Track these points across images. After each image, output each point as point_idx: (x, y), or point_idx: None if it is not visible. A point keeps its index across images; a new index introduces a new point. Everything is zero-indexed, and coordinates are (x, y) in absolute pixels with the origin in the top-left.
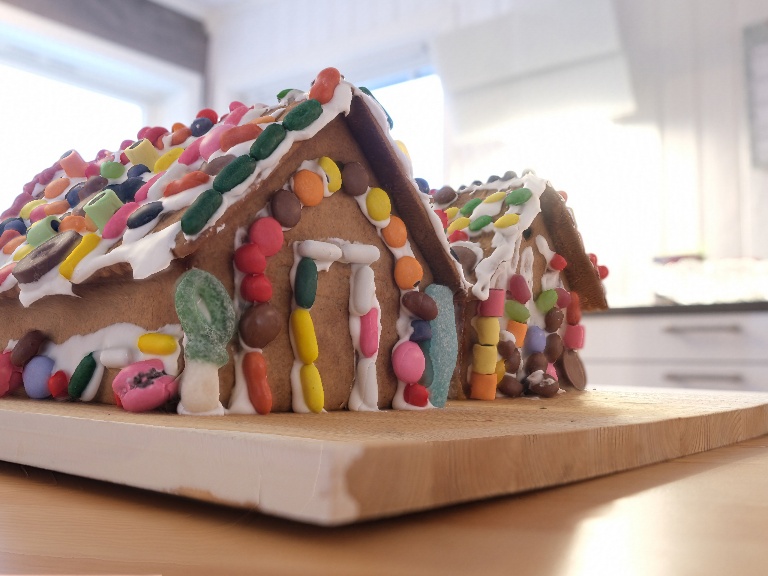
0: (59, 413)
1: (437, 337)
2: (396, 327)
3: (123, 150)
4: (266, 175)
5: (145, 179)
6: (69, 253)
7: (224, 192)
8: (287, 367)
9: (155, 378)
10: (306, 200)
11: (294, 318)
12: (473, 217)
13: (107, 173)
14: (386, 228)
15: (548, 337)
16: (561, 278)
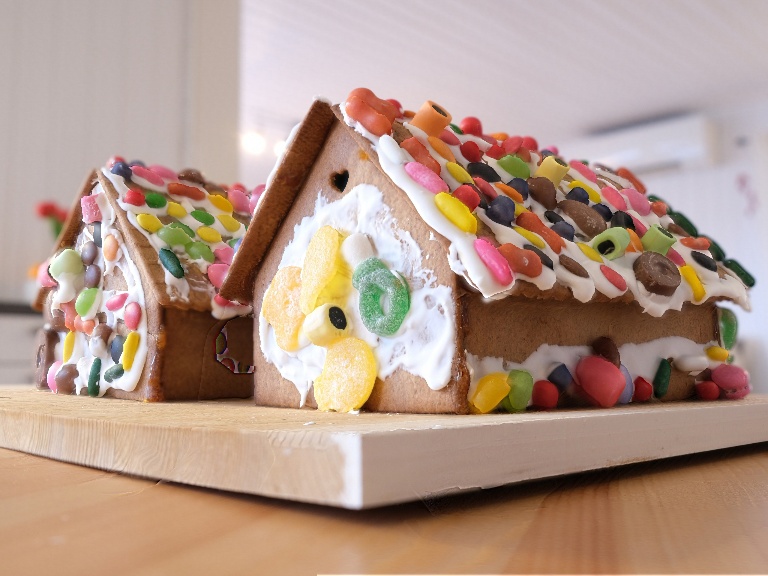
0: None
1: None
2: None
3: None
4: None
5: None
6: None
7: None
8: None
9: None
10: None
11: None
12: None
13: None
14: None
15: None
16: None
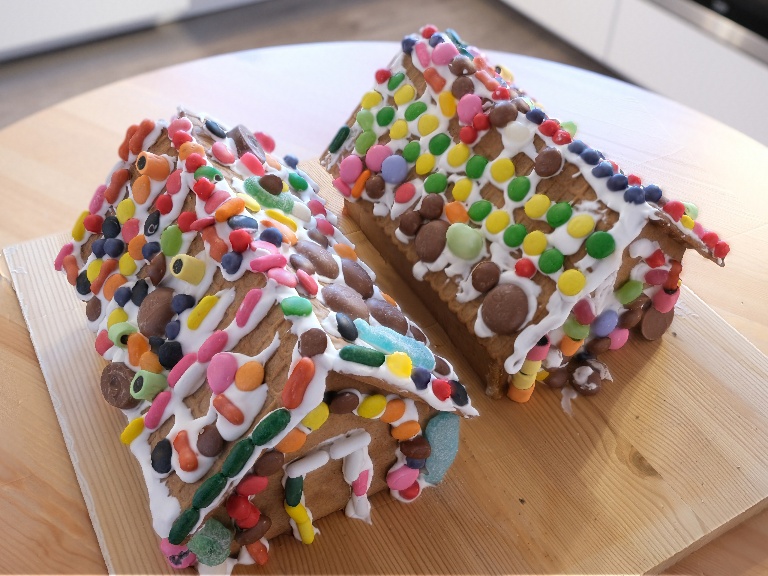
0: (127, 575)
1: (433, 457)
2: (395, 453)
3: (188, 175)
4: (237, 483)
5: (180, 337)
6: (130, 407)
7: (201, 508)
8: (286, 519)
9: (183, 558)
10: None
11: None
12: (551, 241)
13: (166, 251)
14: (381, 416)
15: (625, 313)
16: (666, 251)
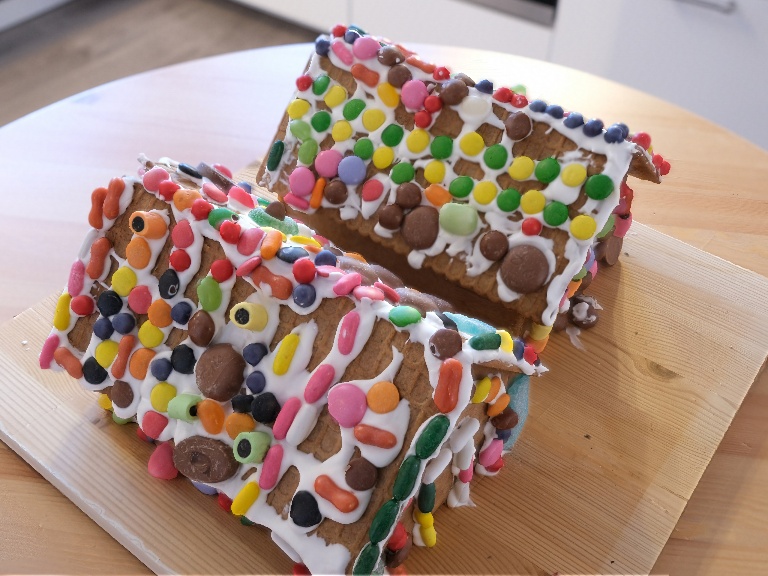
0: None
1: None
2: (483, 432)
3: (199, 223)
4: None
5: (269, 387)
6: (228, 477)
7: None
8: None
9: None
10: None
11: (418, 518)
12: (549, 196)
13: (208, 306)
14: None
15: (597, 246)
16: None
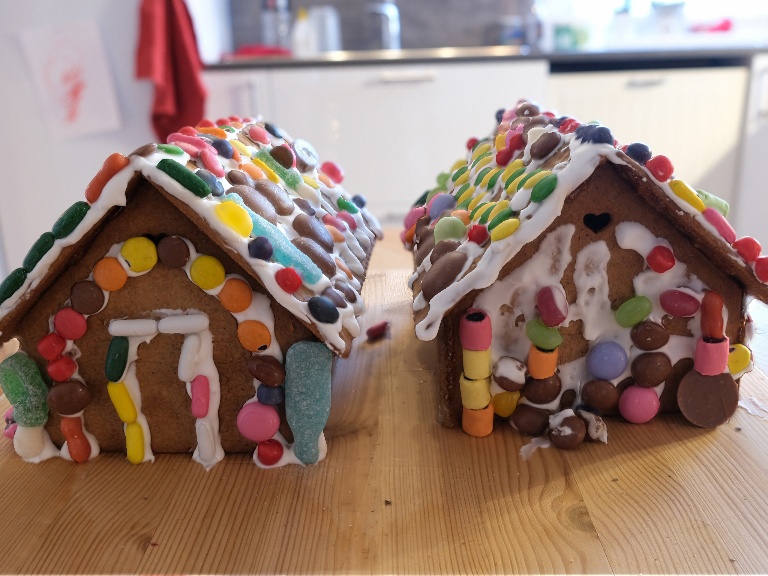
0: None
1: (291, 400)
2: (253, 384)
3: None
4: (35, 285)
5: None
6: None
7: None
8: (120, 421)
9: (14, 423)
10: (105, 288)
11: None
12: (509, 204)
13: None
14: (219, 295)
15: (639, 356)
16: (695, 271)
